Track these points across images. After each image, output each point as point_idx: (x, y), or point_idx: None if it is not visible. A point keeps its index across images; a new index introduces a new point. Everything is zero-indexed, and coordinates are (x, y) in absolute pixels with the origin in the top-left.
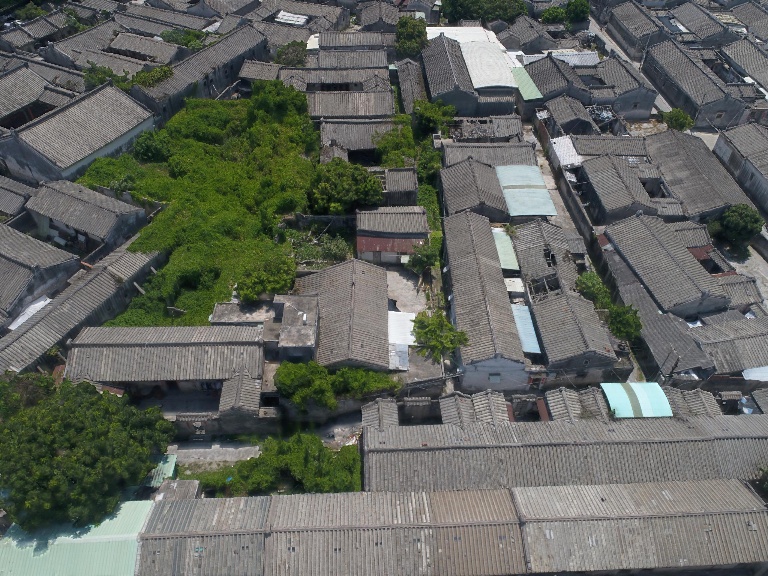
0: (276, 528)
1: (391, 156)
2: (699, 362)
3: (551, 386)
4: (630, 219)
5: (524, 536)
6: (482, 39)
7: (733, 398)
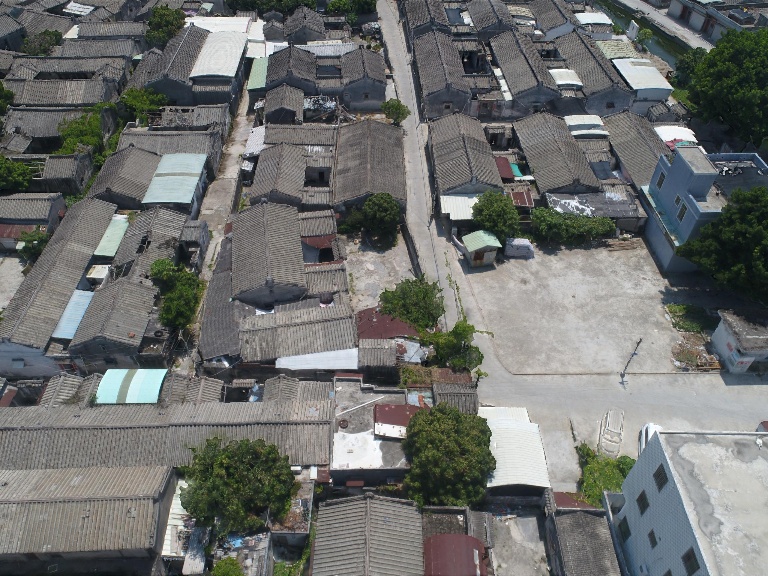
0: None
1: (64, 143)
2: (229, 349)
3: (90, 373)
4: (255, 207)
5: None
6: (240, 29)
7: (244, 386)
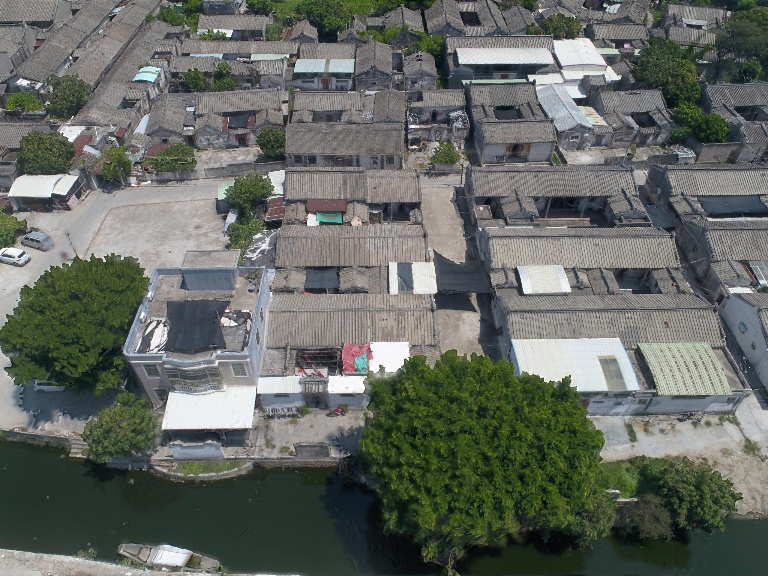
0: (134, 5)
1: None
2: None
3: None
4: None
5: (100, 38)
6: (571, 62)
7: None
